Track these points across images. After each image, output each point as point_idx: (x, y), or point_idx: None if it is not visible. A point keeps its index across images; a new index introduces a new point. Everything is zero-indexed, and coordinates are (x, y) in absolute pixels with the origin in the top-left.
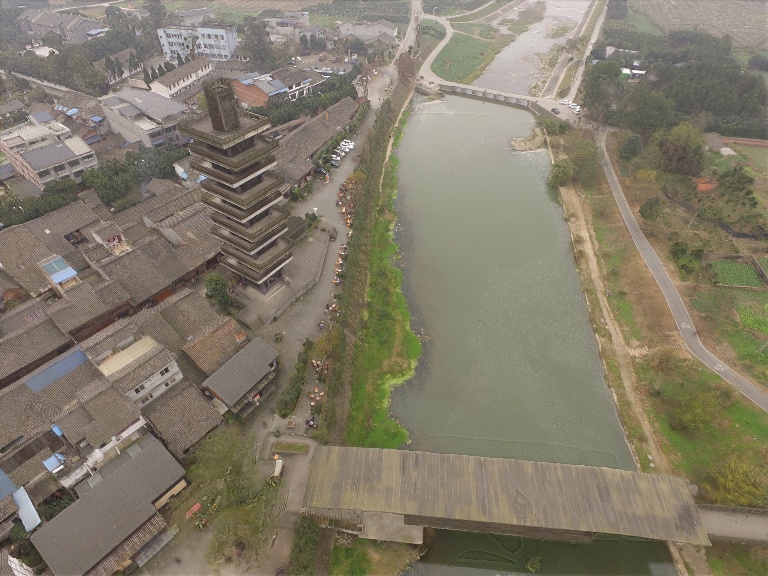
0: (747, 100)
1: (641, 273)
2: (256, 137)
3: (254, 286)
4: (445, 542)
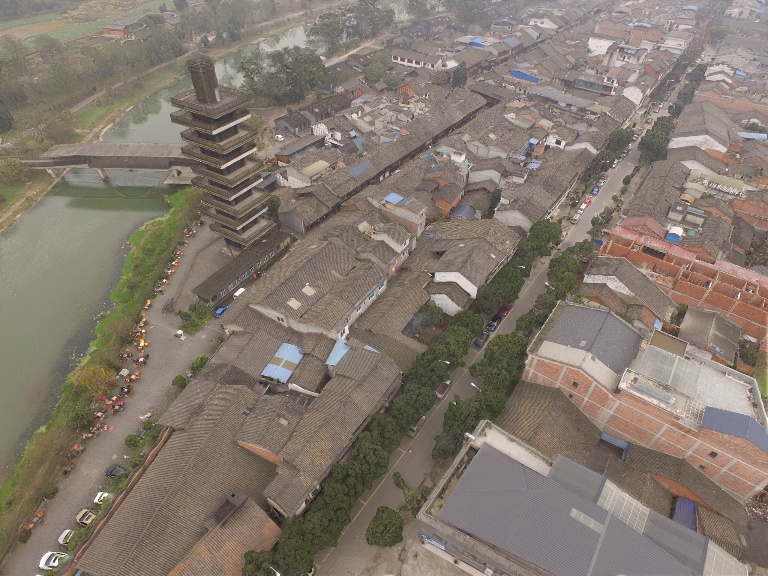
0: None
1: None
2: None
3: None
4: (166, 172)
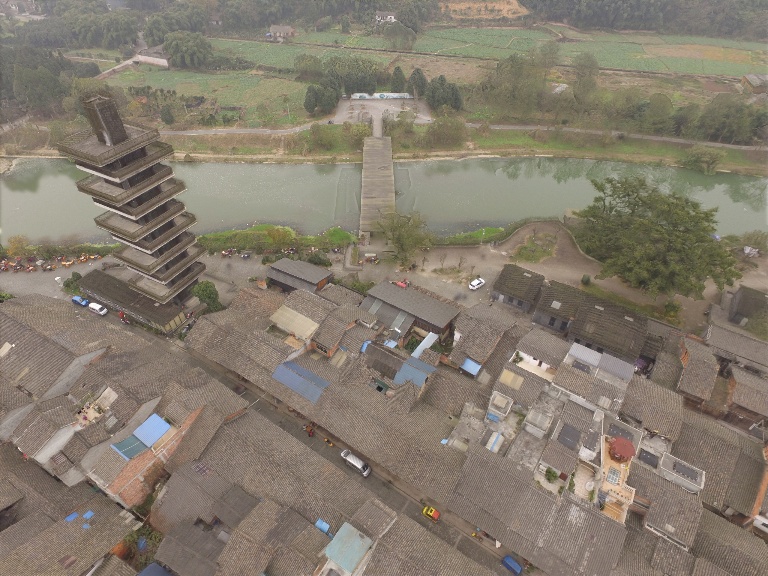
0: (54, 59)
1: (221, 137)
2: None
3: (191, 295)
4: None
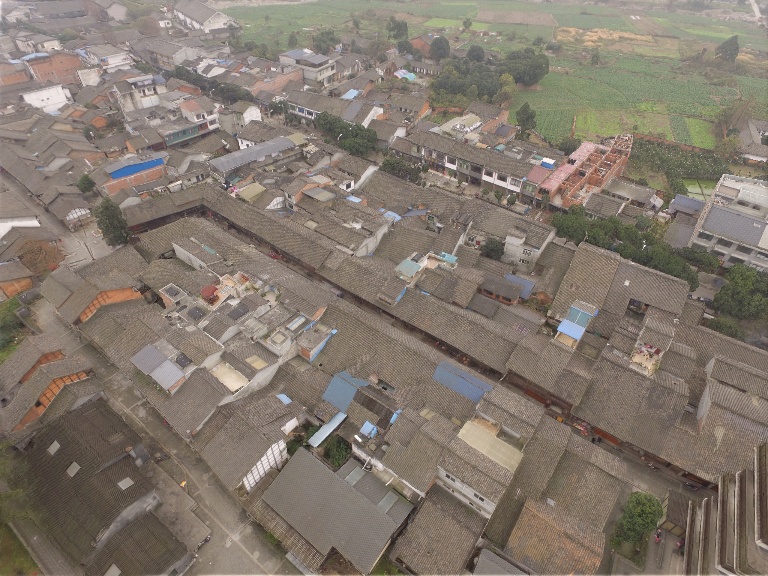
0: None
1: None
2: None
3: None
4: None
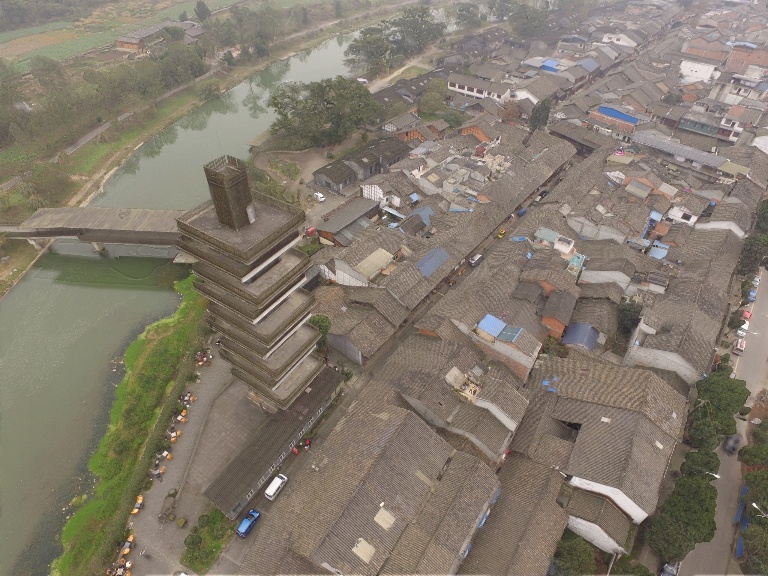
0: None
1: None
2: (207, 252)
3: None
4: None
